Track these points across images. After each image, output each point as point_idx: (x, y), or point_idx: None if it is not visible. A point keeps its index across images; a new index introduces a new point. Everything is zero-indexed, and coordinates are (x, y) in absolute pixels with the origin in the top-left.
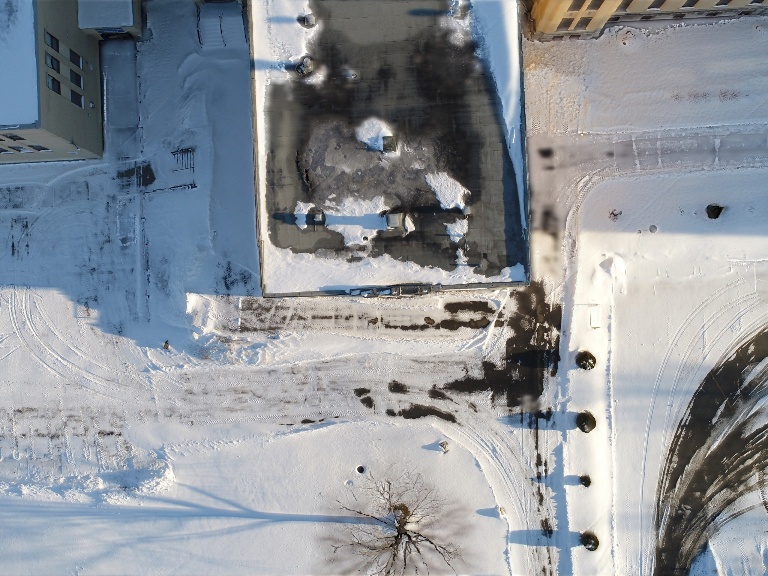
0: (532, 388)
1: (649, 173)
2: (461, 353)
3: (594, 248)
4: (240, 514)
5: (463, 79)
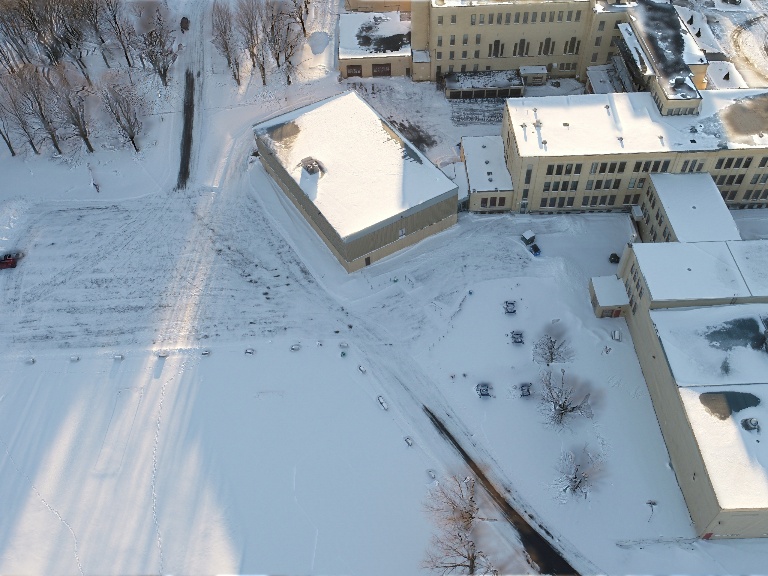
0: None
1: None
2: None
3: None
4: None
5: (764, 101)
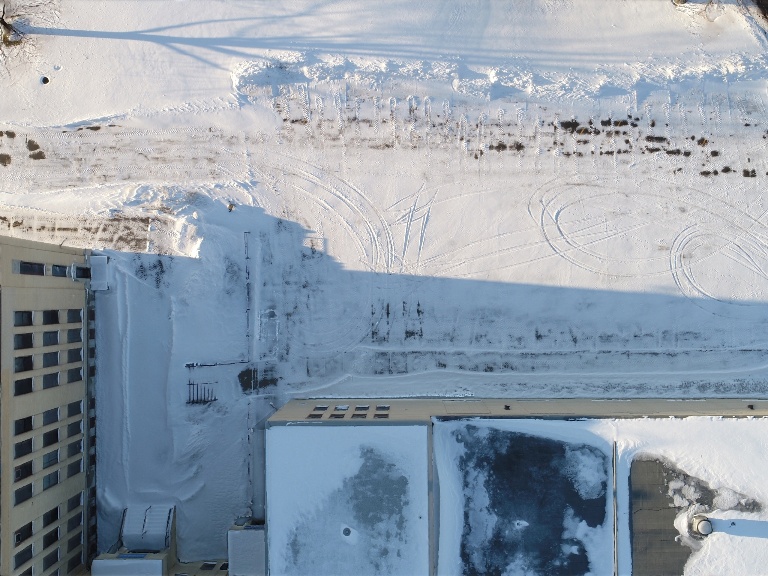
0: None
1: None
2: None
3: None
4: (170, 40)
5: None
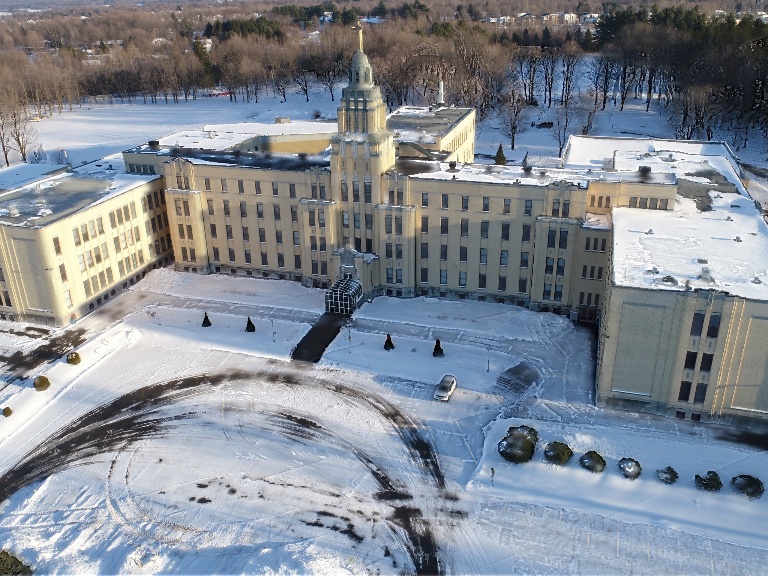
0: (30, 365)
1: (187, 309)
2: (12, 346)
3: (130, 325)
4: None
5: None
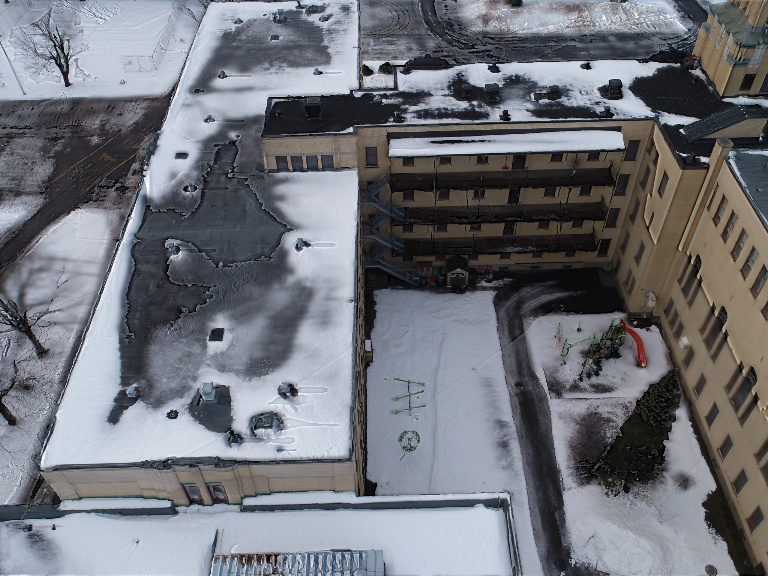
0: None
1: None
2: None
3: None
4: None
5: None
